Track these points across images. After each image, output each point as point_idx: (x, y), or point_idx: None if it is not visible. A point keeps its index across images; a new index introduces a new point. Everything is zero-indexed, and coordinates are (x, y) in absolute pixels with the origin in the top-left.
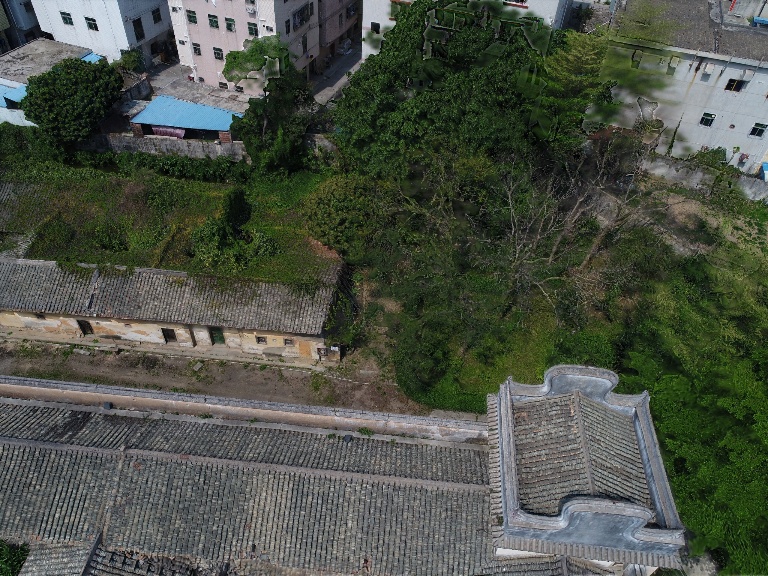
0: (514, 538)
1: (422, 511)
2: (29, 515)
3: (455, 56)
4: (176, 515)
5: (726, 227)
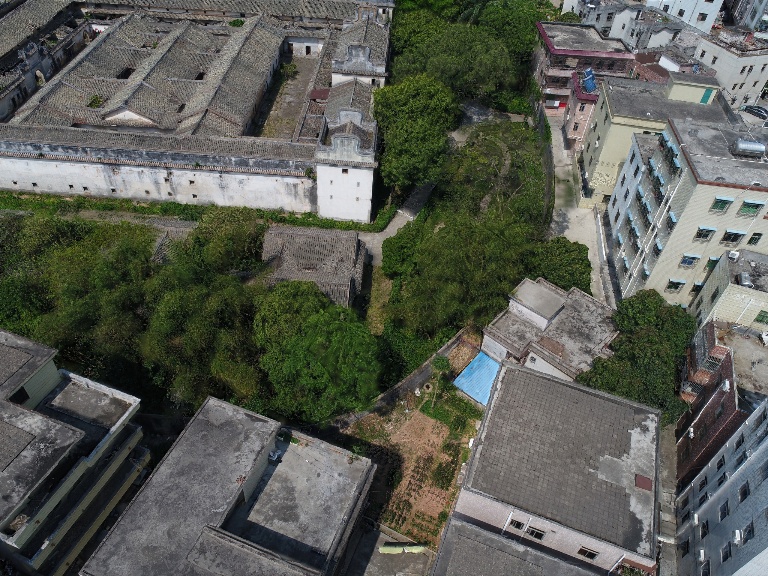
0: (359, 2)
1: (340, 6)
2: (247, 8)
3: None
4: (282, 8)
5: None
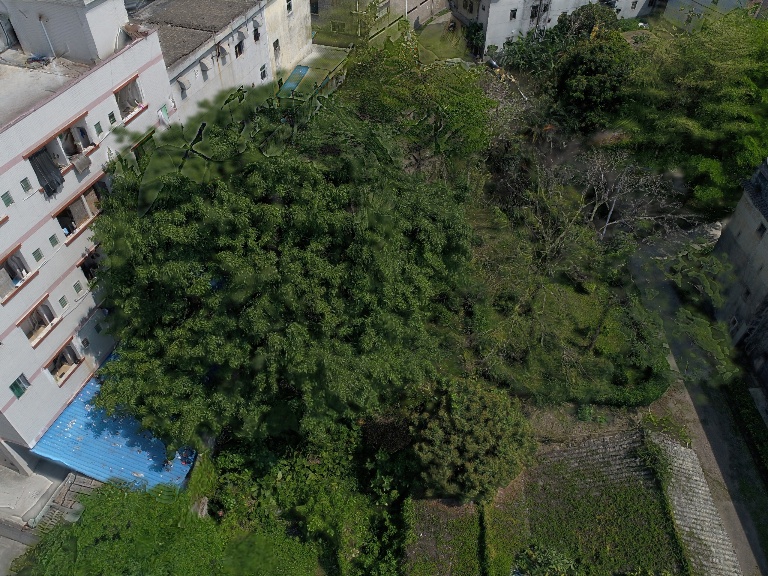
0: None
1: None
2: None
3: (112, 247)
4: None
5: (344, 147)
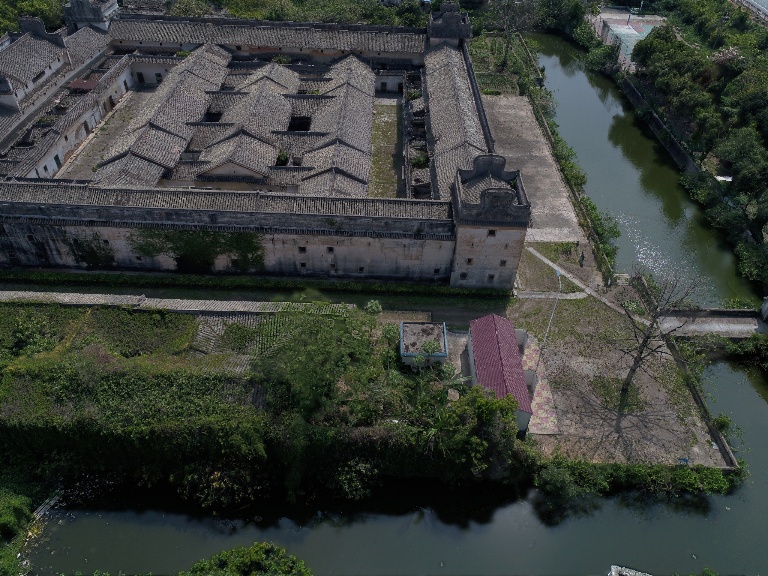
0: None
1: None
2: None
3: None
4: None
5: None
